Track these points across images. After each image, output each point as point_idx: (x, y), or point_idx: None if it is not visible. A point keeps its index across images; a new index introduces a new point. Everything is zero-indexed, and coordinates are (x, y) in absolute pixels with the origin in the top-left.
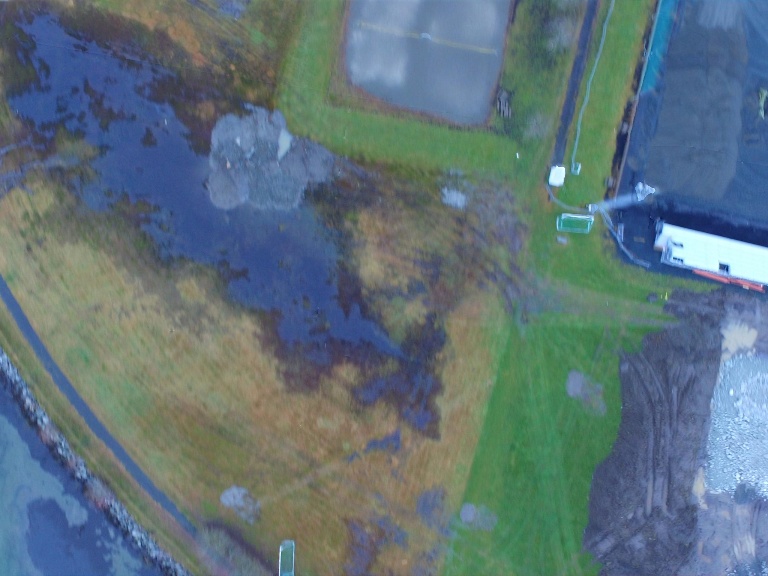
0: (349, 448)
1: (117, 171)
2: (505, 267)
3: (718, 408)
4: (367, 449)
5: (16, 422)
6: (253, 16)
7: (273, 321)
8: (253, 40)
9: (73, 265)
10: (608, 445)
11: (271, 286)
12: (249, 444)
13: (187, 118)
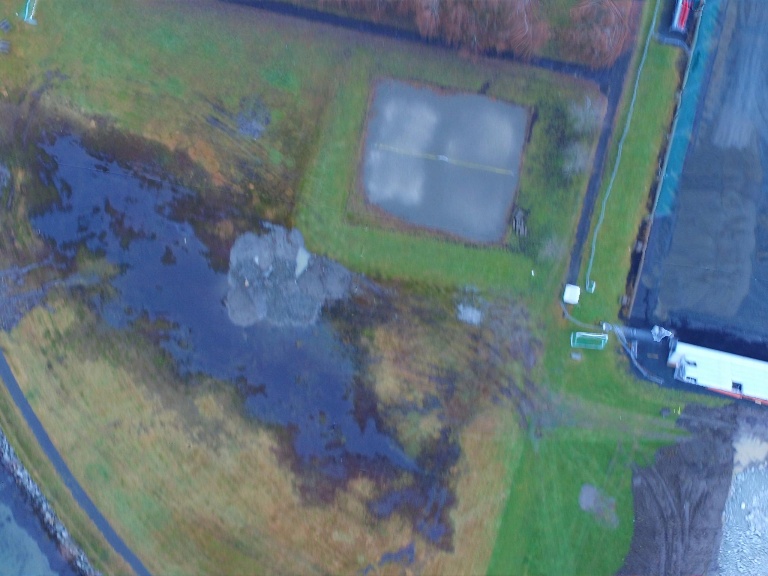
0: (364, 561)
1: (137, 289)
2: (519, 382)
3: (730, 521)
4: (382, 562)
5: (36, 535)
6: (272, 136)
7: (290, 436)
8: (272, 160)
9: (93, 382)
10: (620, 558)
11: (288, 401)
12: (265, 557)
13: (206, 237)
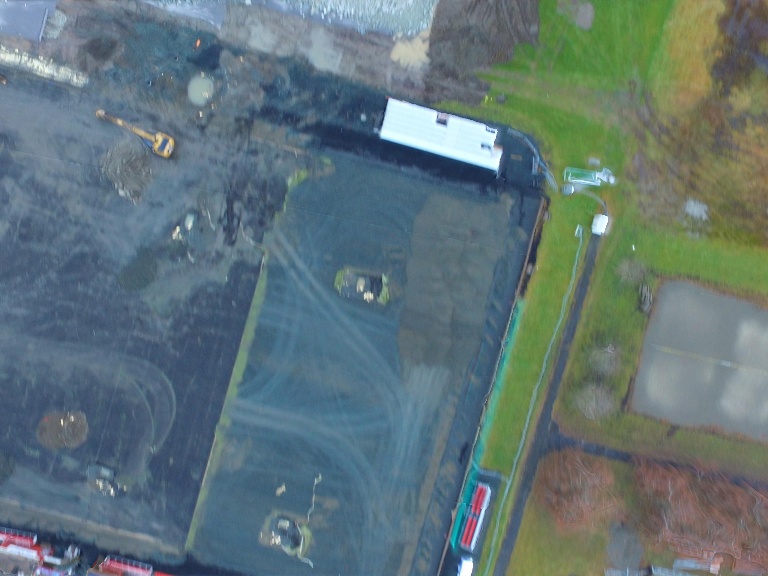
0: None
1: None
2: (651, 138)
3: None
4: None
5: None
6: None
7: None
8: None
9: None
10: None
11: None
12: None
13: None
